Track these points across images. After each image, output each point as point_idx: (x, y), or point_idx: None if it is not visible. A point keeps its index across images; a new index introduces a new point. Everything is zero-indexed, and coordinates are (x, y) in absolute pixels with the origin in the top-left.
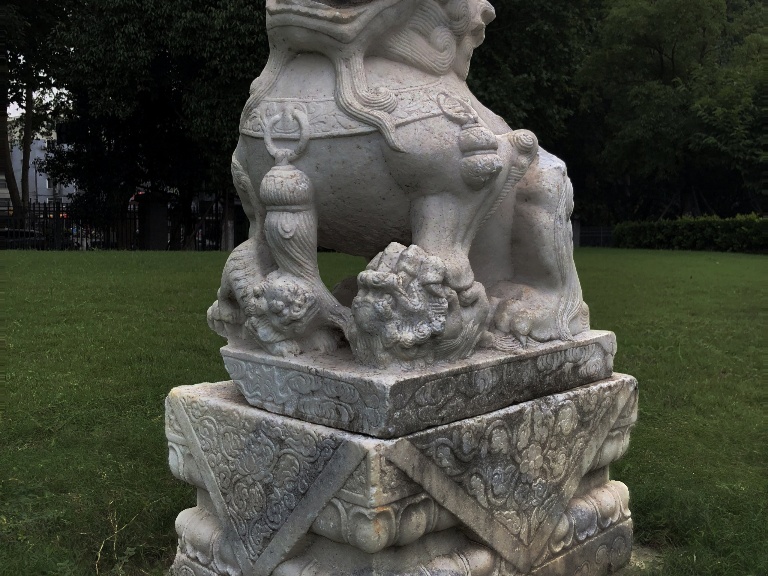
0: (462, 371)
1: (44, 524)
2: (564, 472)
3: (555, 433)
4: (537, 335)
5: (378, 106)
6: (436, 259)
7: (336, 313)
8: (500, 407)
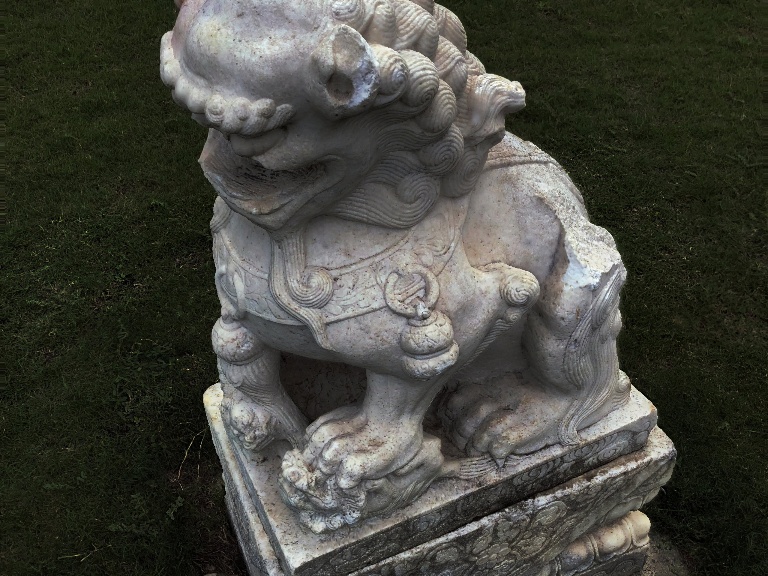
0: (394, 527)
1: (156, 407)
2: (542, 548)
3: (530, 528)
4: (523, 451)
5: (306, 303)
6: (353, 465)
7: (293, 438)
8: (452, 529)
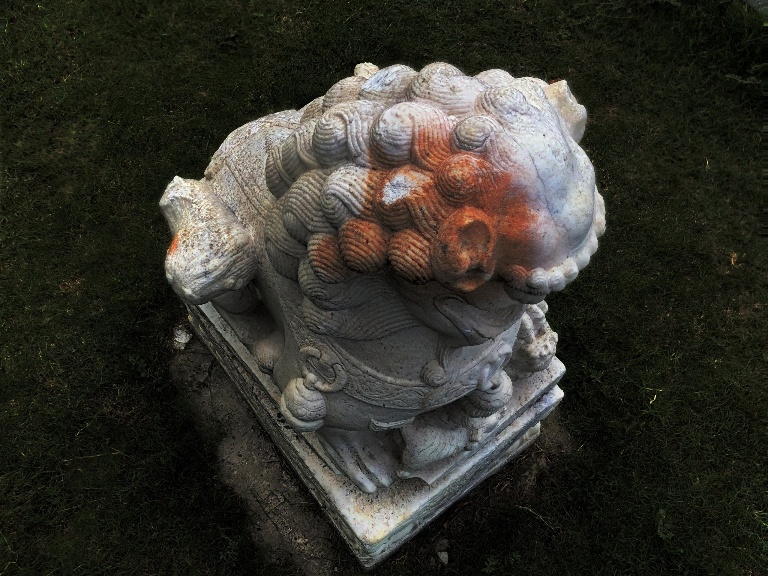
0: None
1: None
2: None
3: None
4: None
5: None
6: None
7: None
8: None
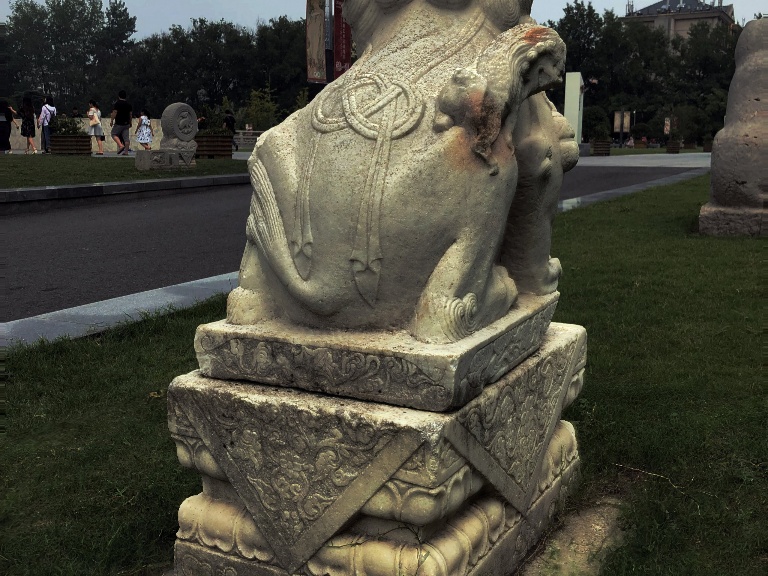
0: None
1: None
2: None
3: None
4: None
5: None
6: None
7: None
8: None
